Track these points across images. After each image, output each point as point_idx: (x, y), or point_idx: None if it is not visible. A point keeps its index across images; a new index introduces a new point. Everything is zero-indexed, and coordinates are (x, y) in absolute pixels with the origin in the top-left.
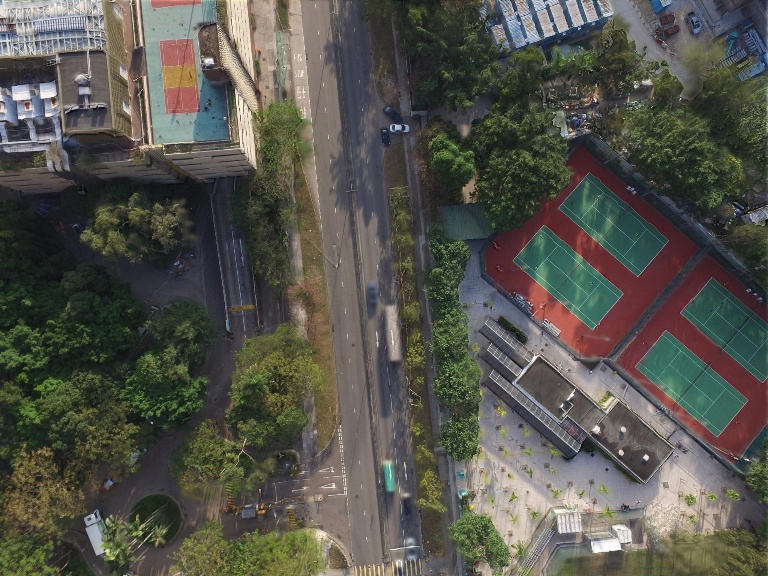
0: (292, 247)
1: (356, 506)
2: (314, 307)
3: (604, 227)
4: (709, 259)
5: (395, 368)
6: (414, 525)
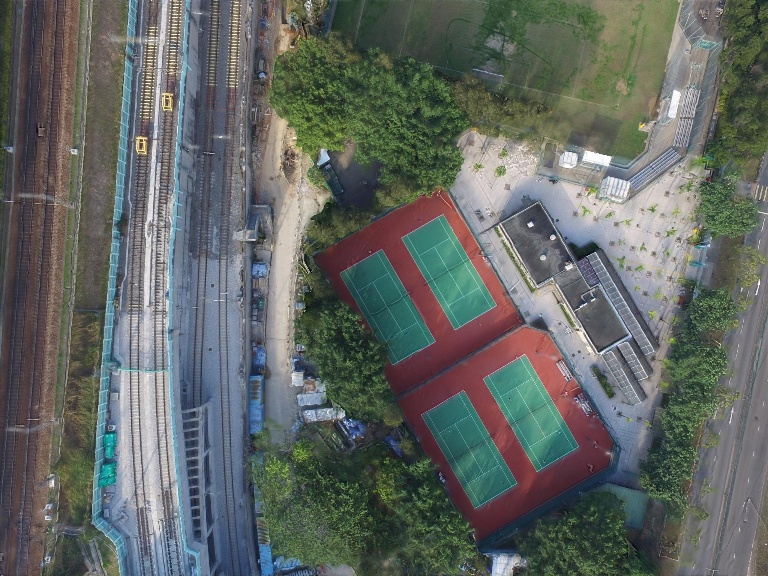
0: None
1: None
2: None
3: (480, 450)
4: (389, 384)
5: (722, 382)
6: None
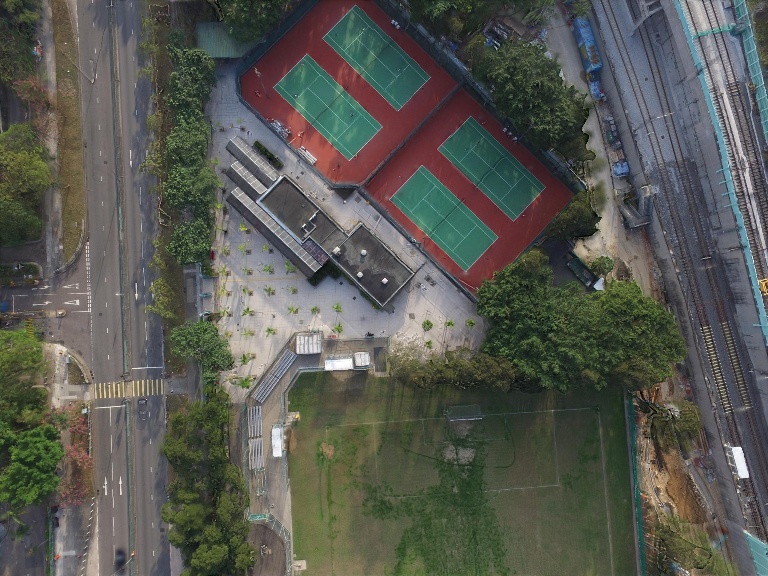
0: (45, 58)
1: (99, 323)
2: (66, 121)
3: (367, 60)
4: (469, 98)
5: (148, 188)
6: (158, 345)
